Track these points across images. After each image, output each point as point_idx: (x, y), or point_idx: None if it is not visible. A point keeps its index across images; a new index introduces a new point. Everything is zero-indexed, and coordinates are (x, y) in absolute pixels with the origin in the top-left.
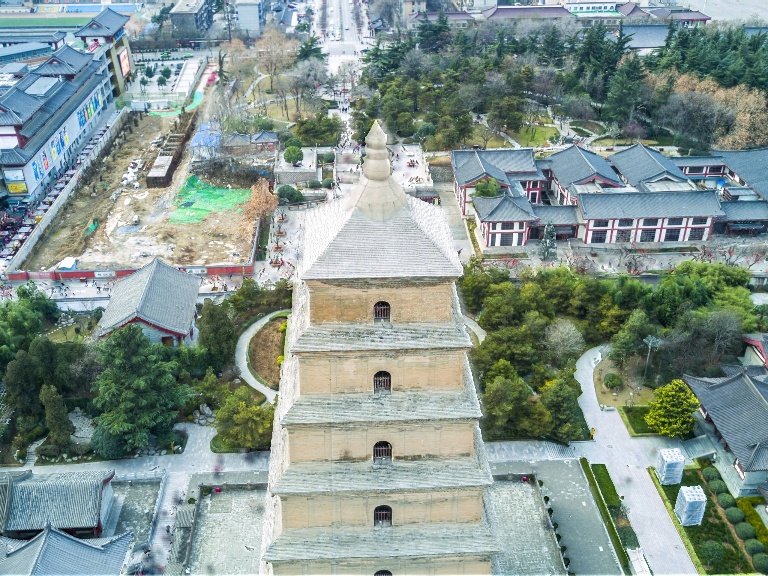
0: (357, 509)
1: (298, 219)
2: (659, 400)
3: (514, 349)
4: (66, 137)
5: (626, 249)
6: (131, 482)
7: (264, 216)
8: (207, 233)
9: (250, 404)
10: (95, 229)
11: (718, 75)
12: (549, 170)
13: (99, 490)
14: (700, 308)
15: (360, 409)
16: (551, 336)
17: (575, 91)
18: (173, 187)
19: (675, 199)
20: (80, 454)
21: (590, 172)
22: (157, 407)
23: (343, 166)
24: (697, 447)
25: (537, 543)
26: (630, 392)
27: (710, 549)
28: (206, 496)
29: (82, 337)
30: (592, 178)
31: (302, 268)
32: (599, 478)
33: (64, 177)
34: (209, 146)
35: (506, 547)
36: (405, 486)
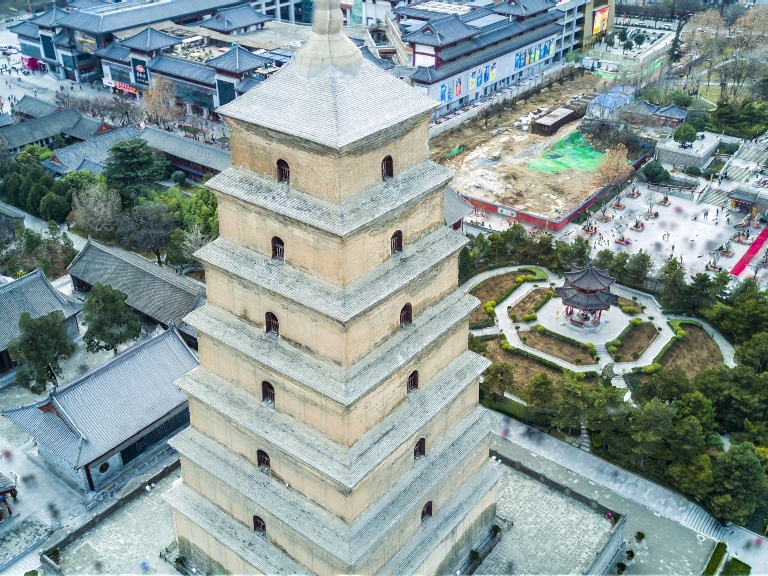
0: (248, 375)
1: None
2: None
3: (734, 392)
4: (493, 73)
5: None
6: None
7: (609, 184)
8: (549, 185)
9: None
10: (457, 153)
11: None
12: None
13: None
14: None
15: (252, 268)
16: None
17: None
18: (552, 137)
19: None
20: None
21: None
22: None
23: (742, 161)
24: None
25: None
26: None
27: None
28: None
29: None
30: None
31: None
32: (727, 575)
33: (468, 106)
34: (602, 105)
35: (521, 560)
36: (275, 366)
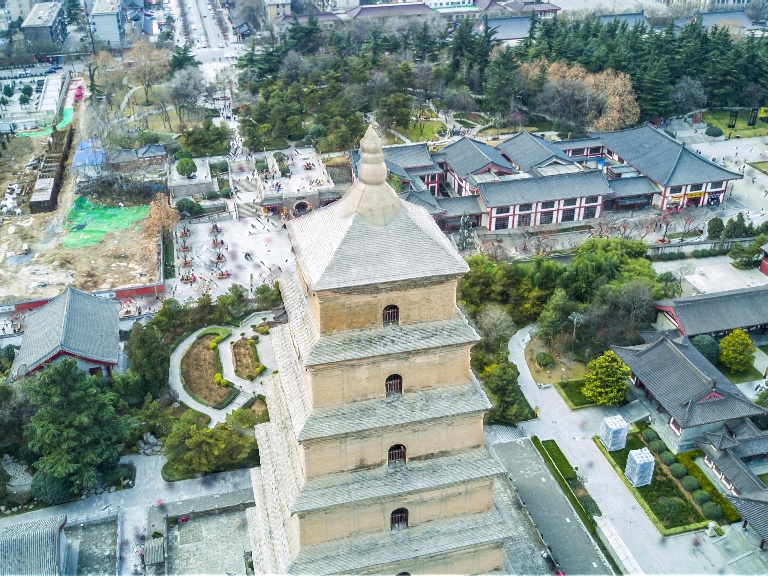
0: (374, 516)
1: (201, 232)
2: (594, 372)
3: None
4: None
5: (528, 233)
6: (83, 525)
7: (167, 232)
8: (107, 255)
9: (200, 427)
10: None
11: (584, 62)
12: (444, 163)
13: (56, 539)
14: (612, 281)
15: (375, 415)
16: (484, 323)
17: (455, 84)
18: (60, 210)
19: (567, 181)
20: (20, 504)
21: (485, 162)
22: (101, 443)
23: (238, 174)
24: (632, 412)
25: (512, 524)
26: (562, 368)
27: (667, 505)
28: (173, 528)
29: (2, 379)
30: (488, 167)
31: (311, 280)
32: (551, 453)
33: None
34: (95, 164)
35: None
36: (423, 486)
